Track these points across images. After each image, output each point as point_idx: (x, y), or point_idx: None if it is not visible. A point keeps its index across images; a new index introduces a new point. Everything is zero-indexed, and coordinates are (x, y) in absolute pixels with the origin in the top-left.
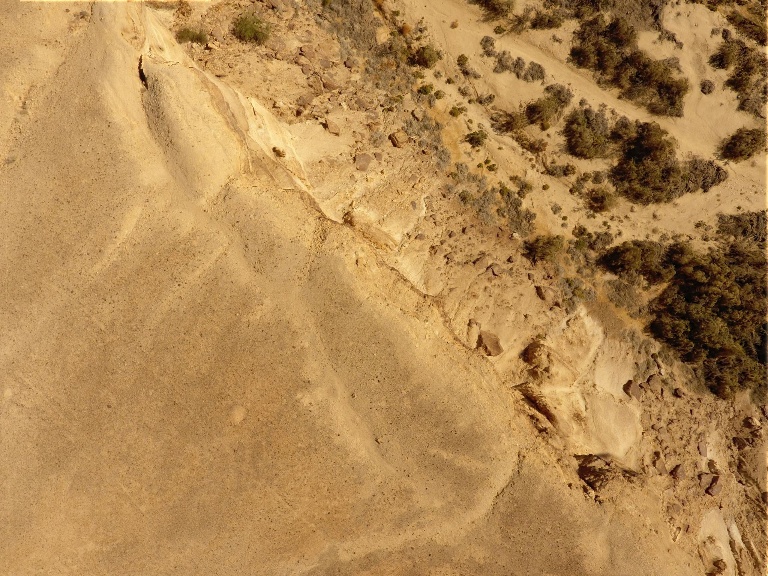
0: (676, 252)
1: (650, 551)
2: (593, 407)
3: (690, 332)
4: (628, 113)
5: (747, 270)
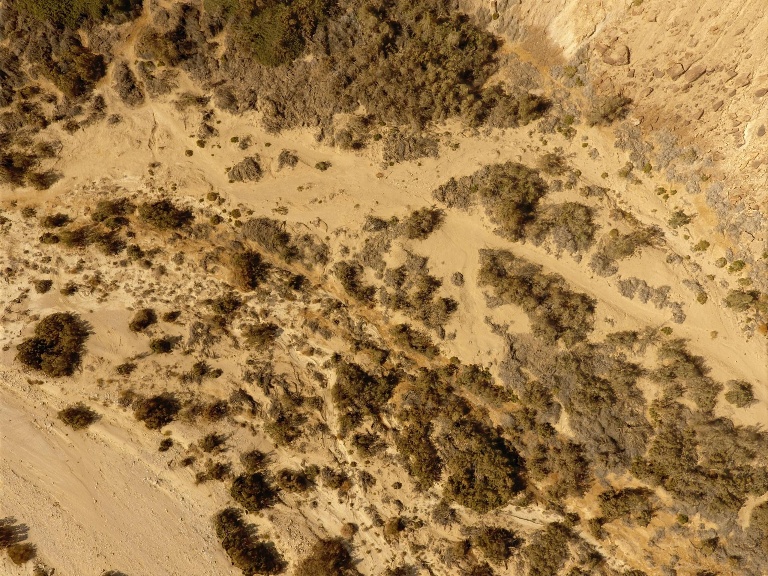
0: (479, 117)
1: None
2: None
3: (462, 43)
4: (532, 251)
5: (420, 99)
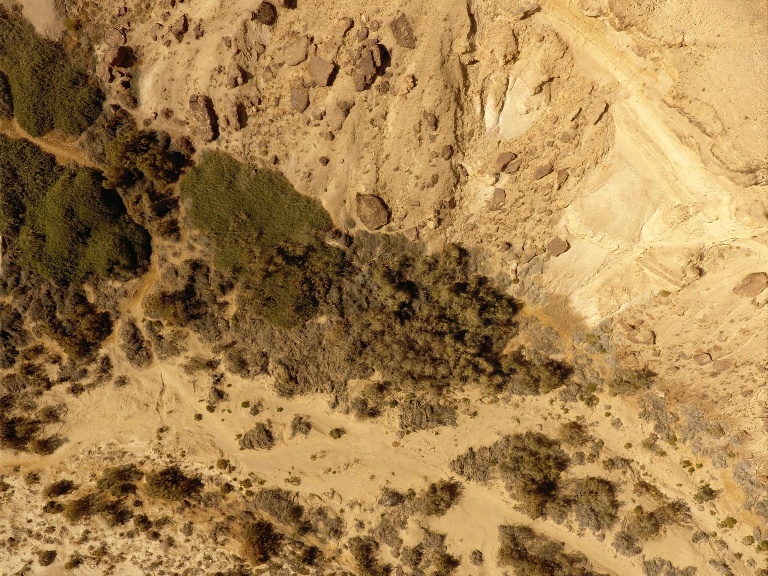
0: None
1: (763, 100)
2: (636, 229)
3: (480, 307)
4: (553, 528)
5: (437, 372)
